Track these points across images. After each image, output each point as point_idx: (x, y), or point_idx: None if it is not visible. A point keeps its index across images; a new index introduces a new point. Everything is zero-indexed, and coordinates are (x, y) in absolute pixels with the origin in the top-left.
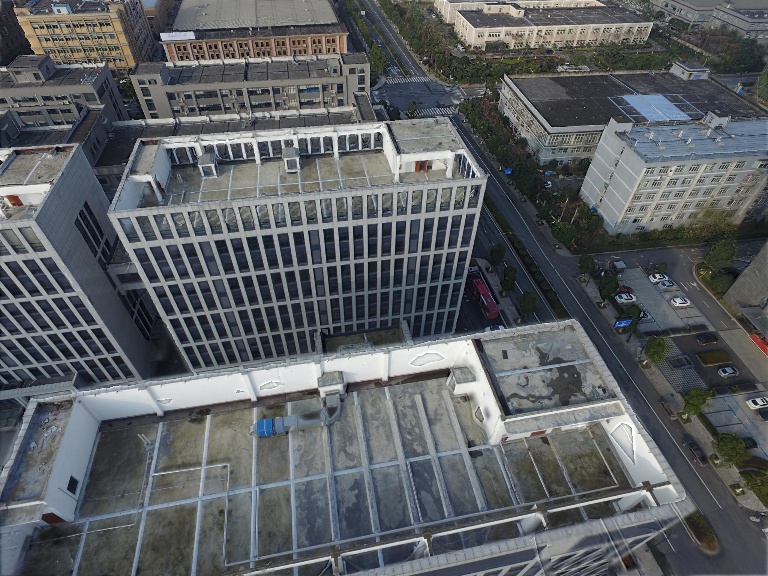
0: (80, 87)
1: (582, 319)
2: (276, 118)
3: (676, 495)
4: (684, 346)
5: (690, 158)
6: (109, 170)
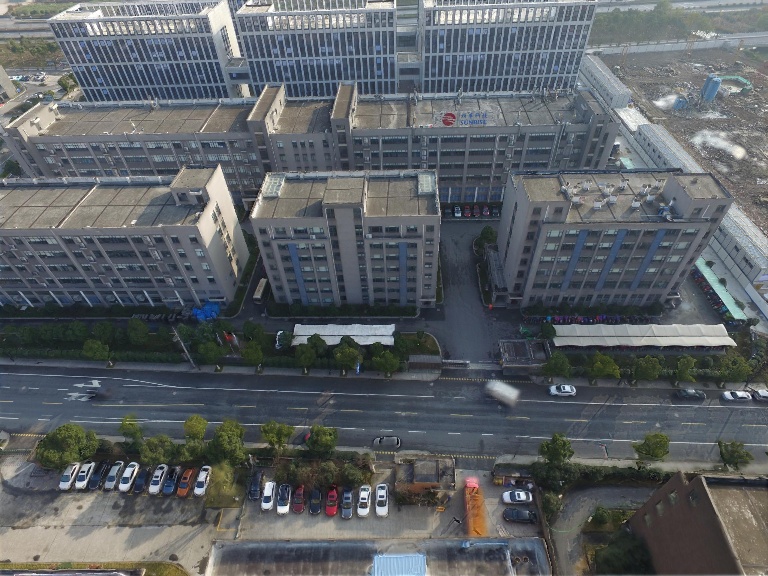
0: (284, 175)
1: None
2: None
3: None
4: None
5: None
6: None
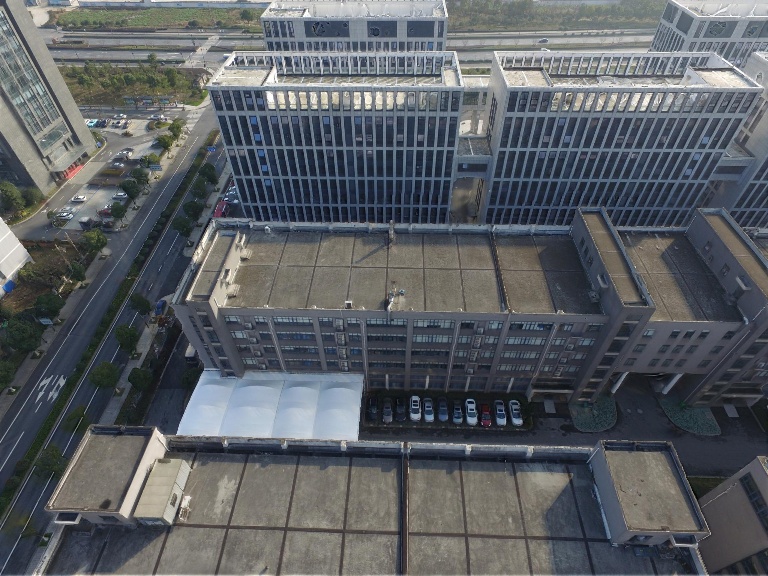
0: None
1: (162, 202)
2: (351, 304)
3: (276, 0)
4: (120, 180)
5: None
6: (550, 229)
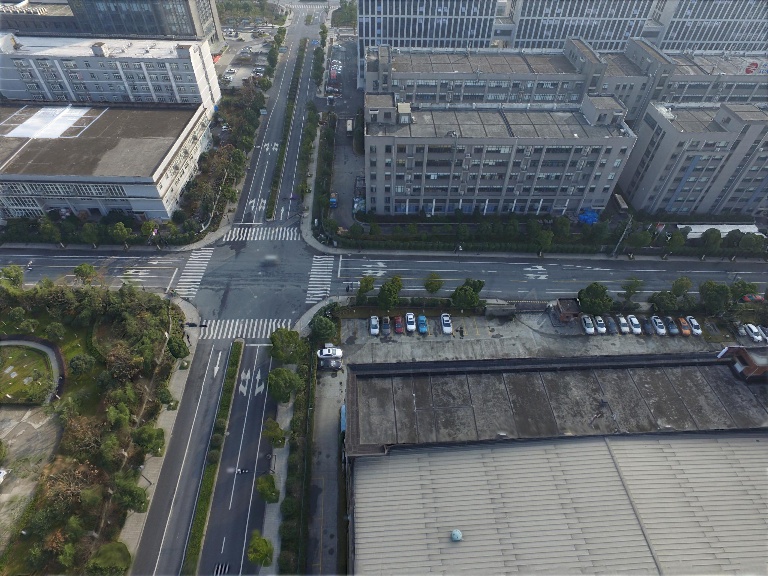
0: (661, 104)
1: (288, 74)
2: None
3: None
4: (252, 63)
5: (173, 39)
6: (553, 51)
